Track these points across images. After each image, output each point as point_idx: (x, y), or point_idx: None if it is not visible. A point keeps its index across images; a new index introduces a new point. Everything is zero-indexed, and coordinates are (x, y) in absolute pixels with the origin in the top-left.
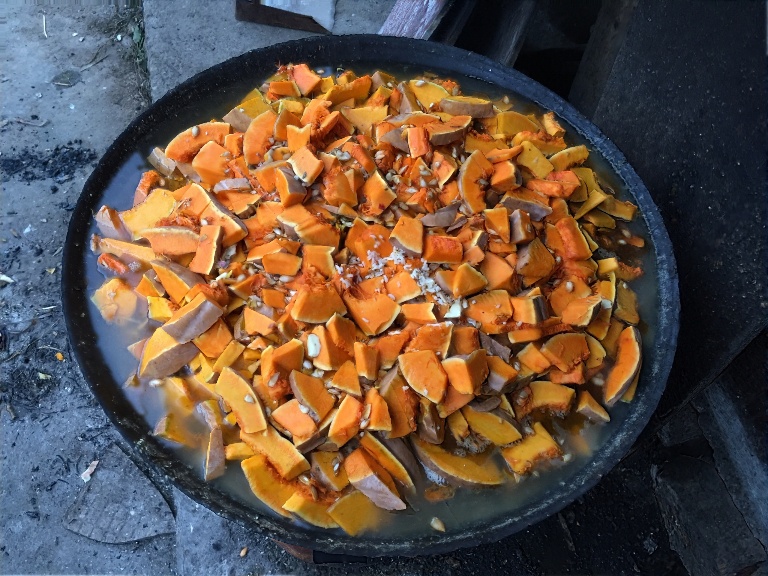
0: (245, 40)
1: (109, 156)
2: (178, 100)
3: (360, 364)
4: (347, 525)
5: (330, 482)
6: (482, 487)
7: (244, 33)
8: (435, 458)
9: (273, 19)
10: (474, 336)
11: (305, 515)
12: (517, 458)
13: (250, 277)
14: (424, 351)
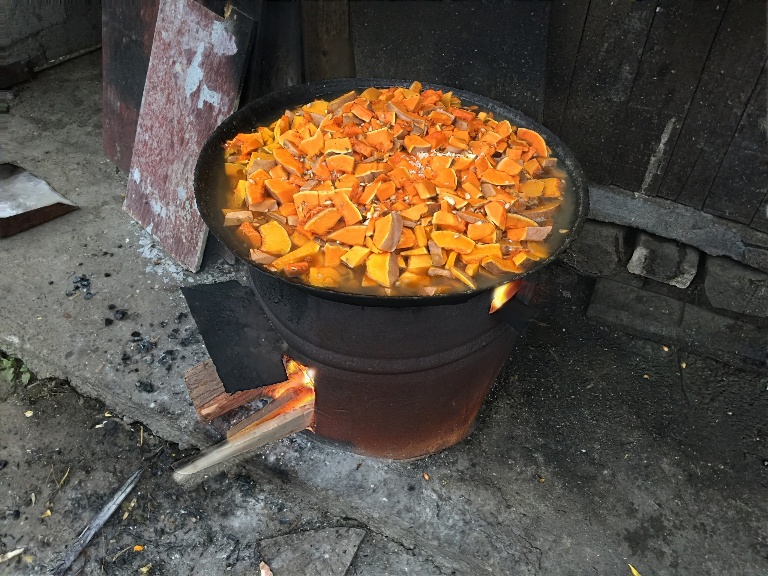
0: (17, 251)
1: (214, 230)
2: (201, 189)
3: (474, 192)
4: (542, 254)
5: (516, 247)
6: (557, 209)
7: (9, 248)
8: (533, 211)
9: (25, 223)
10: (491, 157)
11: (529, 257)
12: (552, 192)
13: (380, 206)
14: (487, 170)
